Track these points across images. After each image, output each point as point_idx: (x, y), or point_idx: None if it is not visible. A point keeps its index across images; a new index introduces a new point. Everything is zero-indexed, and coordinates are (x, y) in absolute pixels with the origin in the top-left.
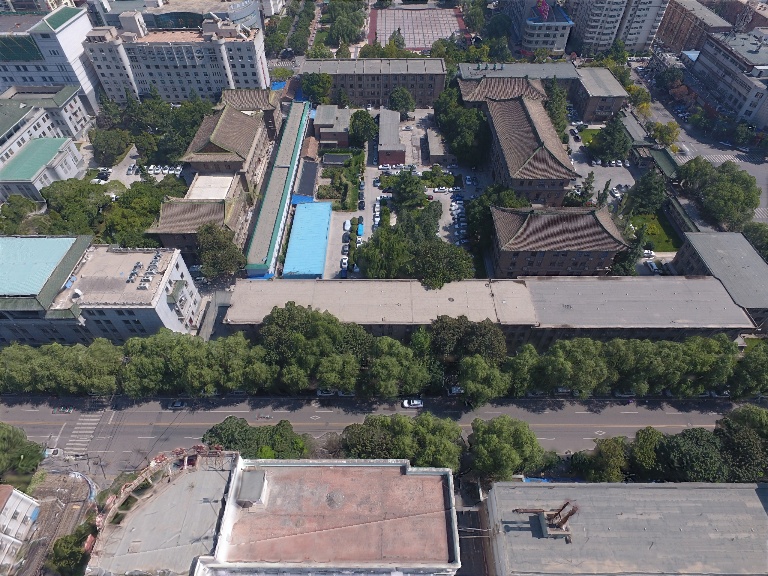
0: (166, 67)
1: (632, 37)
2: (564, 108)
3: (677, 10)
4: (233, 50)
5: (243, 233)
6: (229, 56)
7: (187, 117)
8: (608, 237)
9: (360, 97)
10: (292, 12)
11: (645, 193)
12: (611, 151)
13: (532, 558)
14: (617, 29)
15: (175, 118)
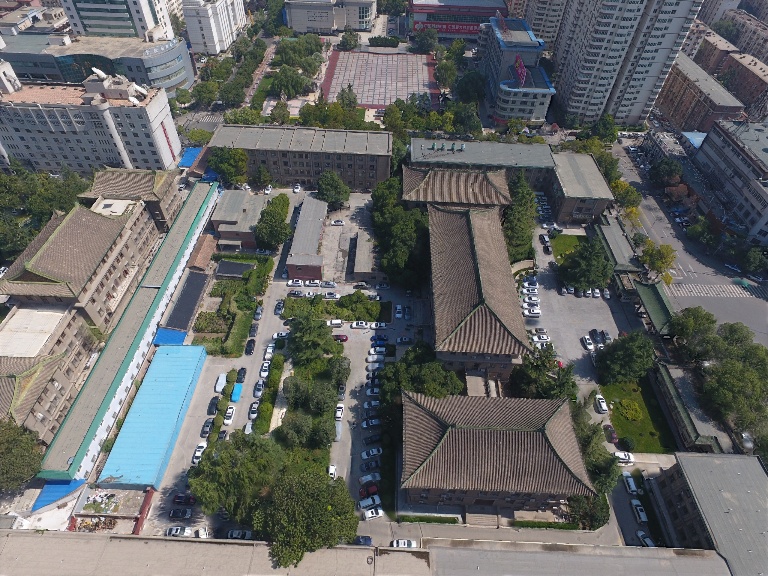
0: (39, 131)
1: (624, 109)
2: (532, 211)
3: (678, 78)
4: (121, 116)
5: (63, 401)
6: (117, 123)
7: (43, 207)
8: (563, 469)
9: (286, 175)
10: (238, 52)
11: (625, 359)
12: (586, 279)
13: None
14: (607, 99)
15: (29, 206)
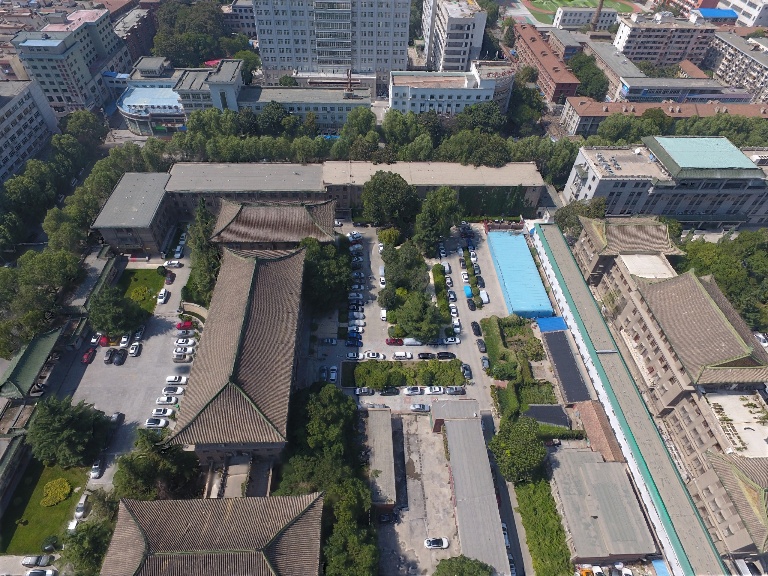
0: None
1: None
2: None
3: None
4: None
5: None
6: None
7: None
8: None
9: None
10: None
11: None
12: None
13: (360, 92)
14: None
15: None
